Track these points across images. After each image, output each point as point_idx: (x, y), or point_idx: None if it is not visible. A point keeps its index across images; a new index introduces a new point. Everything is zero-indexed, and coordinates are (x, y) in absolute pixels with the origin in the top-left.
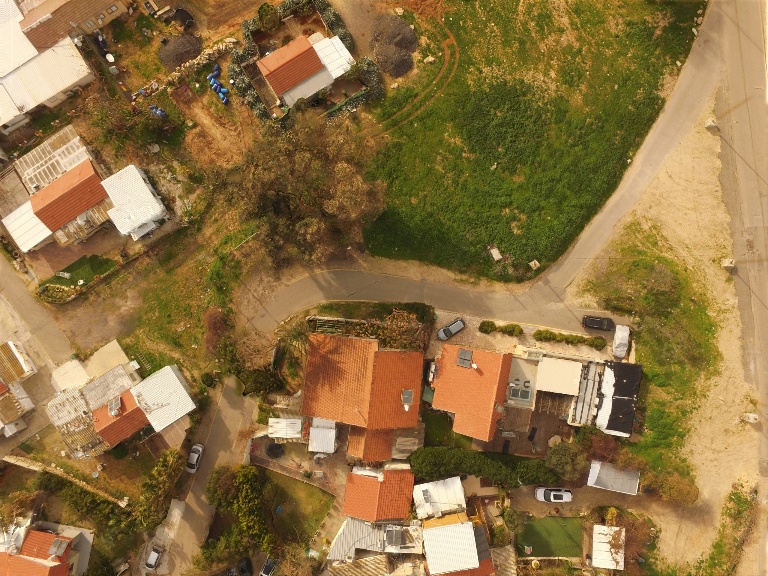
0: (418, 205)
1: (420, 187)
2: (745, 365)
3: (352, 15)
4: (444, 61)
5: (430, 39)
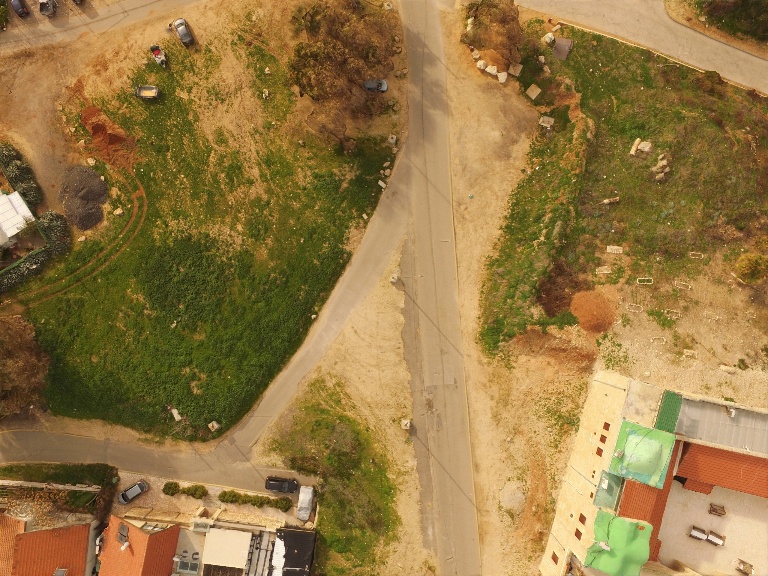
0: (98, 364)
1: (101, 345)
2: (423, 530)
3: (43, 166)
4: (132, 214)
5: (121, 190)
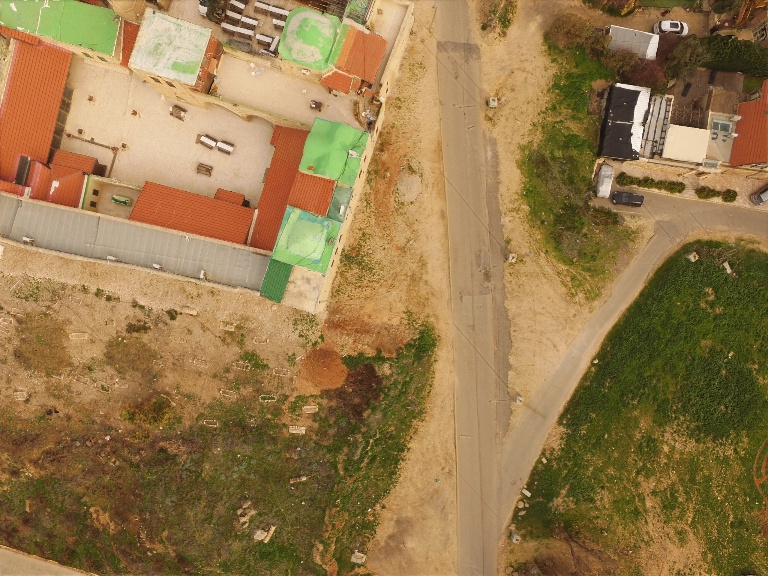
0: None
1: None
2: (496, 155)
3: None
4: (767, 461)
5: None
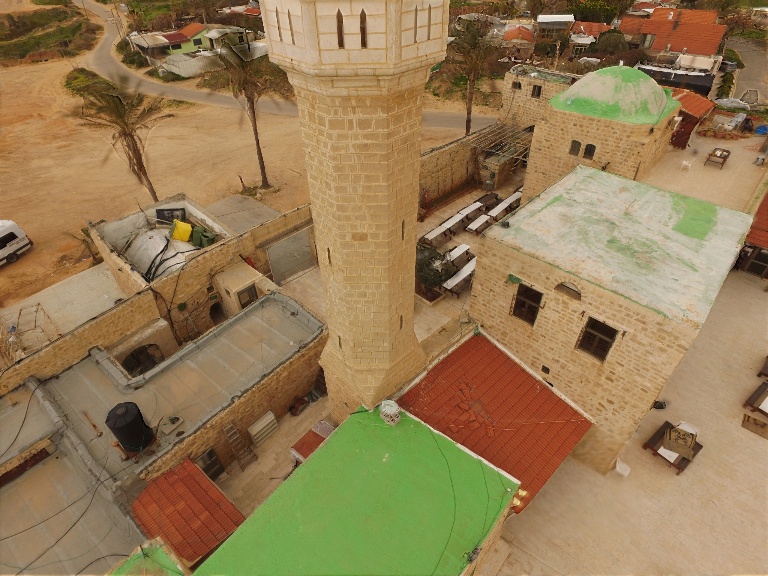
0: None
1: None
2: None
3: None
4: None
5: None
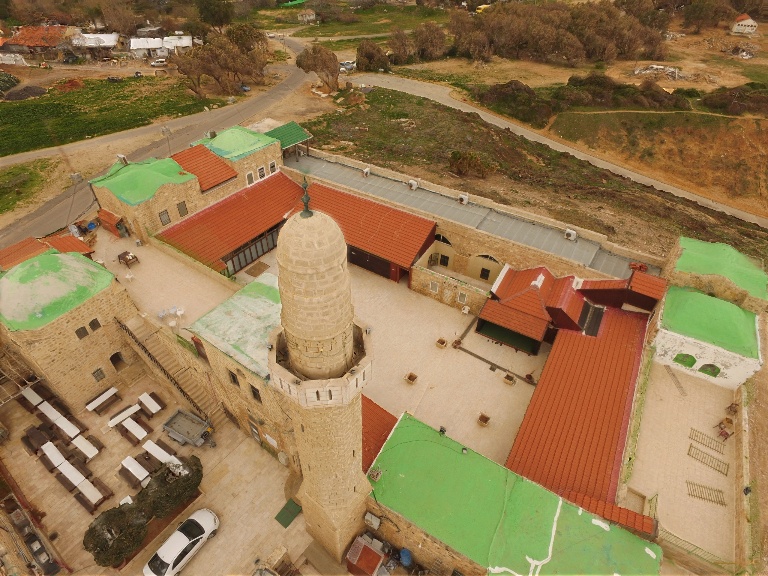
0: None
1: None
2: None
3: None
4: (43, 98)
5: None
